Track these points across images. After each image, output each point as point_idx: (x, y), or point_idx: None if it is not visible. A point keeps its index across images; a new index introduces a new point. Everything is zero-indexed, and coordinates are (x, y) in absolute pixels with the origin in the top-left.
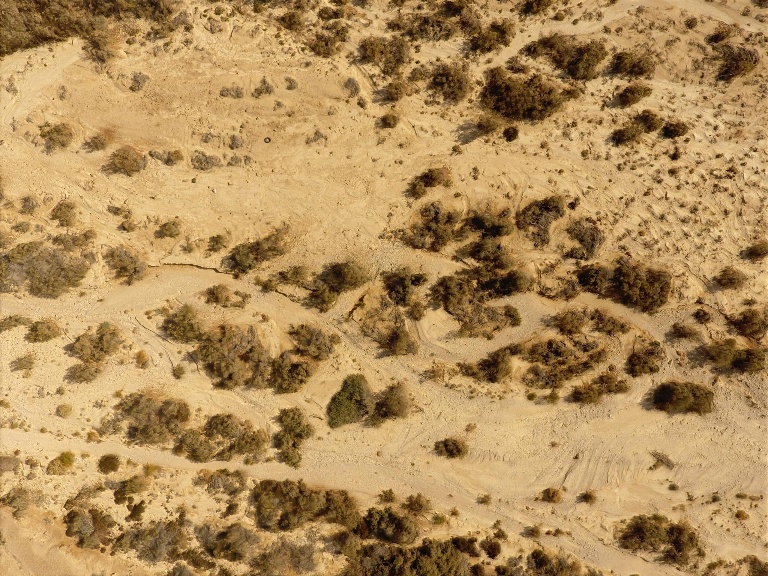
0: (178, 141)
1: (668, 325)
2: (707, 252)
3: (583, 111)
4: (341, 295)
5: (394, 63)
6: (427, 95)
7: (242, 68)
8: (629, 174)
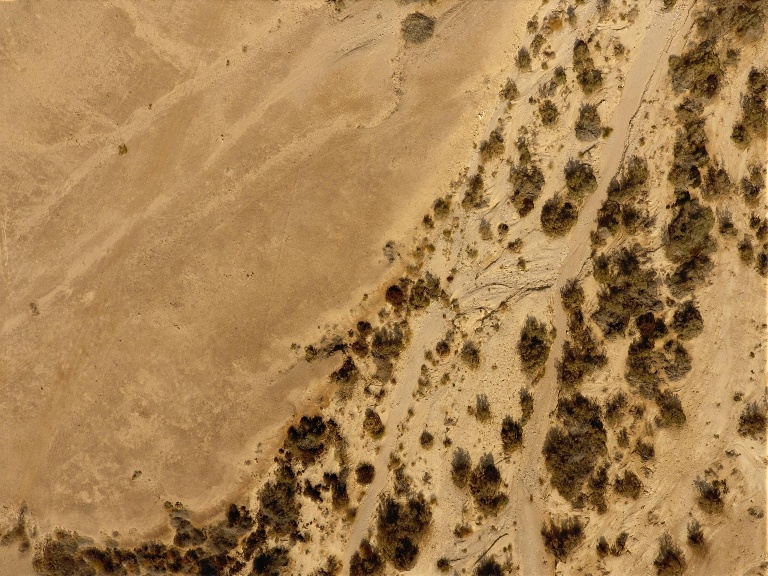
0: None
1: None
2: None
3: None
4: None
5: None
6: None
7: None
8: None
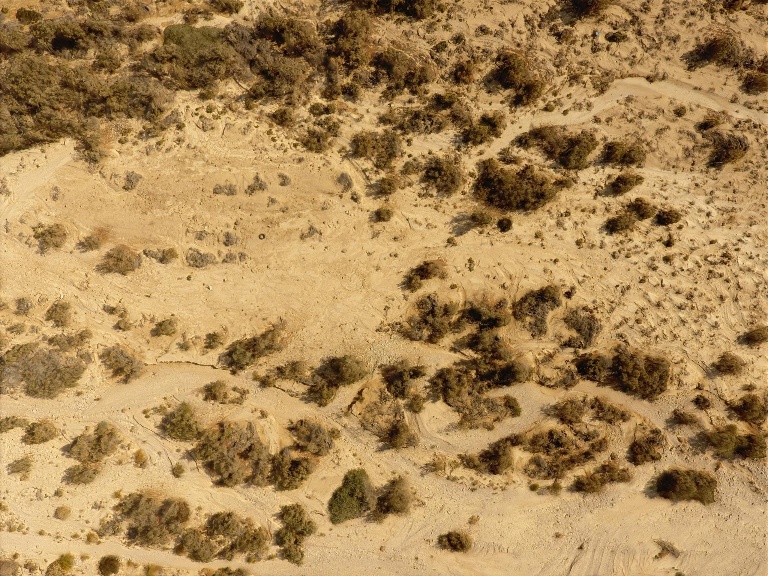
0: (172, 239)
1: (668, 411)
2: (704, 338)
3: (576, 200)
4: (340, 389)
5: (386, 157)
6: (420, 188)
7: (235, 165)
8: (624, 262)
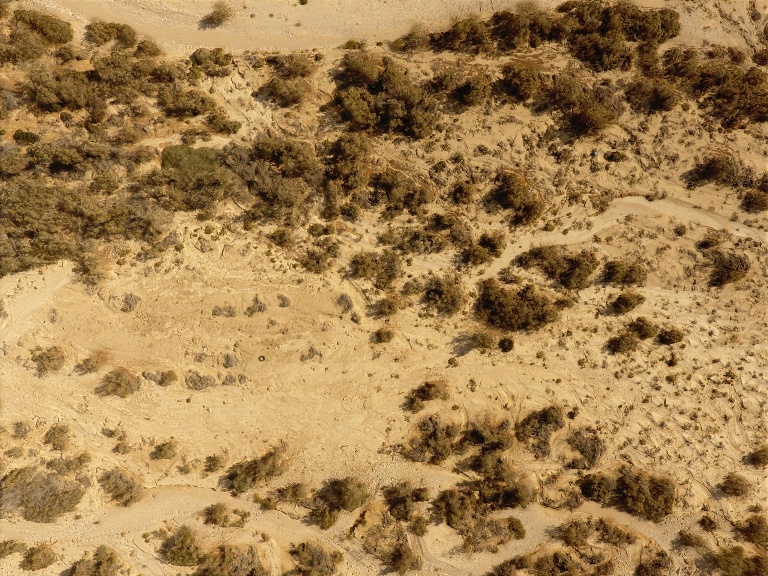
0: (171, 361)
1: (674, 532)
2: (709, 459)
3: (577, 320)
4: (342, 512)
5: (386, 279)
6: (420, 308)
7: (234, 286)
8: (627, 381)
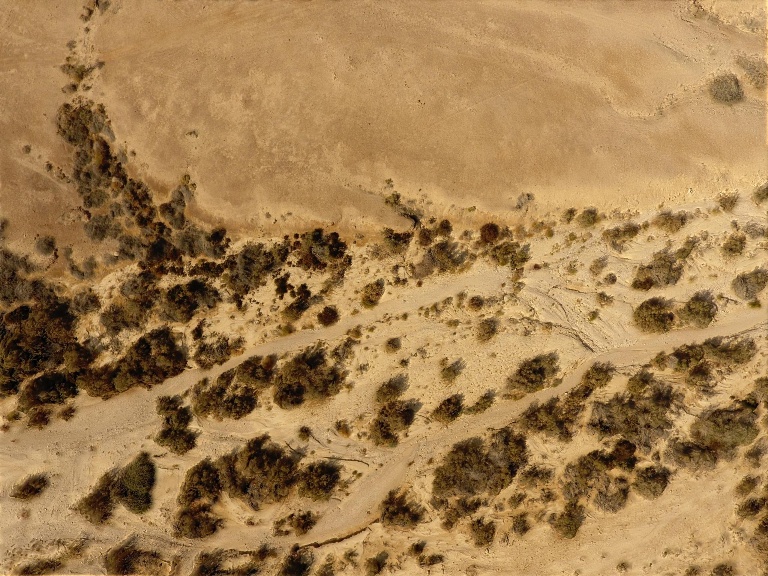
0: None
1: None
2: None
3: None
4: None
5: None
6: None
7: None
8: None
